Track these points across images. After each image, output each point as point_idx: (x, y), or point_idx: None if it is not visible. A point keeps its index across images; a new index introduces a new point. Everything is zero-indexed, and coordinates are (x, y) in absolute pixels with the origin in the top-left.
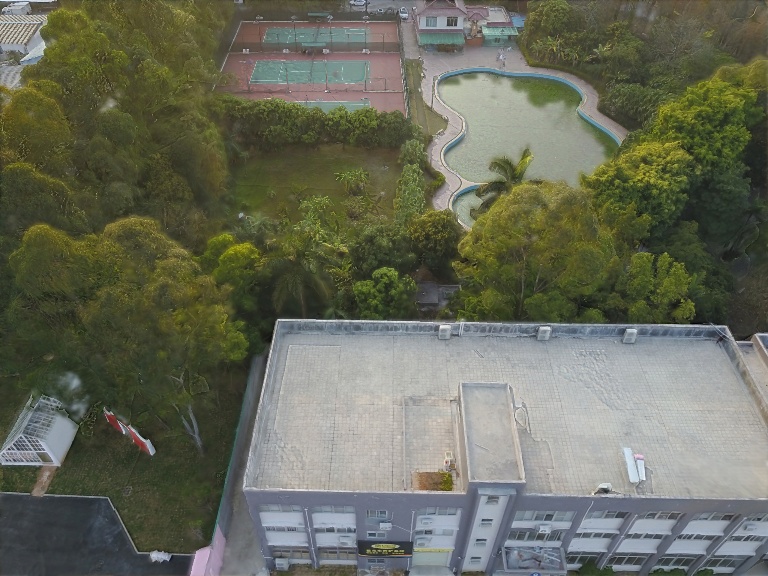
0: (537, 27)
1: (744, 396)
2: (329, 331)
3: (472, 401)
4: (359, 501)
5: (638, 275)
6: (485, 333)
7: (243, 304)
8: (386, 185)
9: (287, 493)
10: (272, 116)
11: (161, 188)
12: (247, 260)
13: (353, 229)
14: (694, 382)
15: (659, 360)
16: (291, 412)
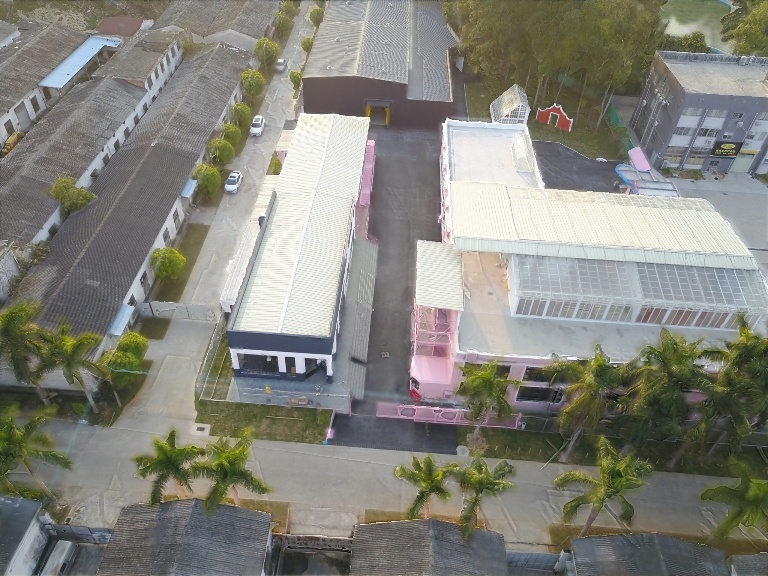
0: None
1: None
2: (680, 60)
3: None
4: (735, 104)
5: None
6: (762, 64)
7: None
8: None
9: (706, 95)
10: None
11: None
12: None
13: None
14: None
15: None
16: (683, 81)
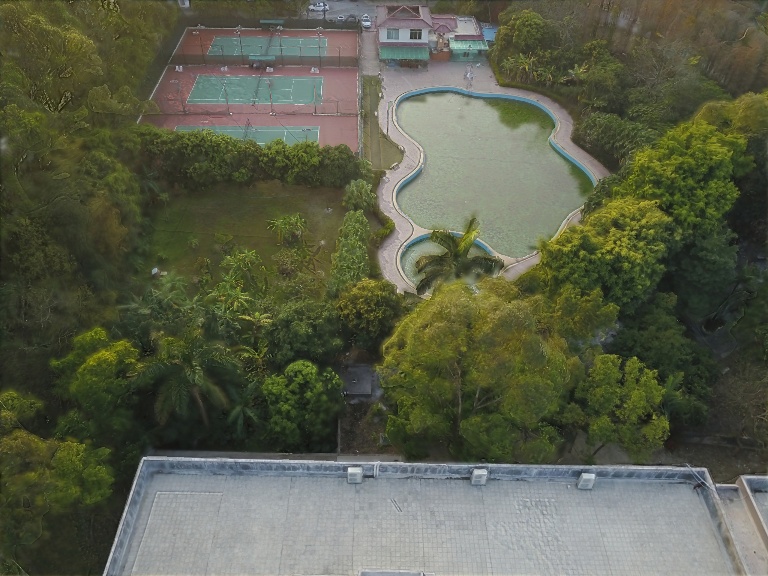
0: (508, 42)
1: (726, 573)
2: (211, 470)
3: None
4: None
5: (602, 384)
6: (407, 474)
7: (112, 424)
8: (327, 232)
9: None
10: (197, 151)
11: (32, 260)
12: (119, 366)
13: (282, 291)
14: (664, 550)
15: (622, 515)
16: None
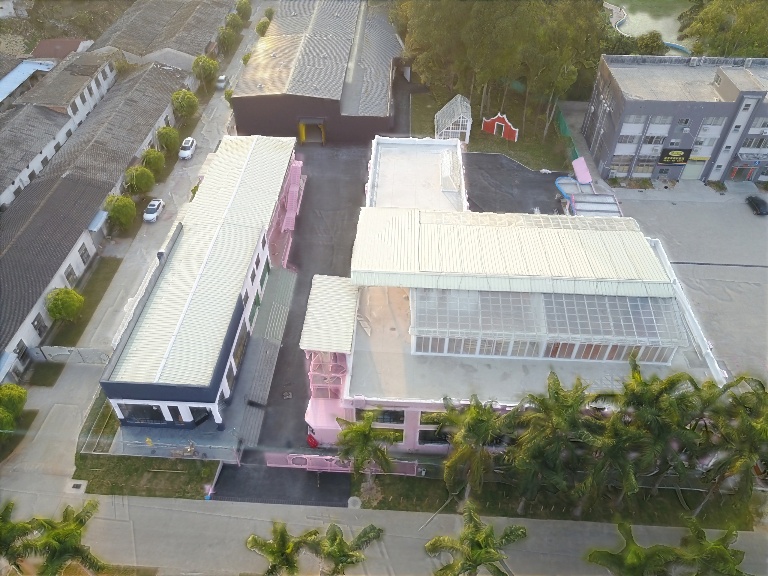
0: None
1: None
2: (628, 63)
3: (728, 73)
4: (679, 110)
5: None
6: (714, 64)
7: None
8: None
9: (647, 102)
10: None
11: None
12: None
13: None
14: None
15: None
16: (627, 86)
